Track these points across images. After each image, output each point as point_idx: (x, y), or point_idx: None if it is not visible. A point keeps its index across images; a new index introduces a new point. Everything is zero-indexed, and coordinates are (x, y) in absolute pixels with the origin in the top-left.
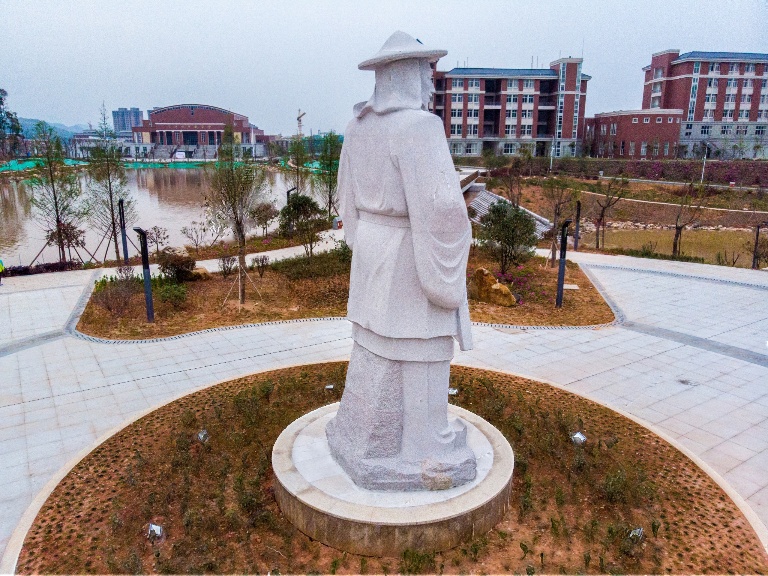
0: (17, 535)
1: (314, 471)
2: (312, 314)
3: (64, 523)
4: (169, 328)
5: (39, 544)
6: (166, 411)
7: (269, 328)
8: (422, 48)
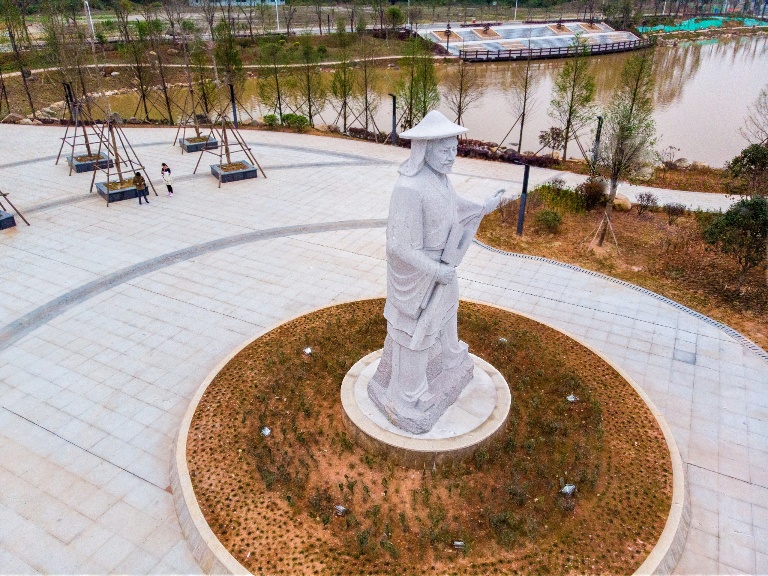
0: (284, 321)
1: (372, 371)
2: (642, 280)
3: (299, 326)
4: (521, 245)
5: (283, 329)
6: None
7: (581, 276)
8: (423, 132)
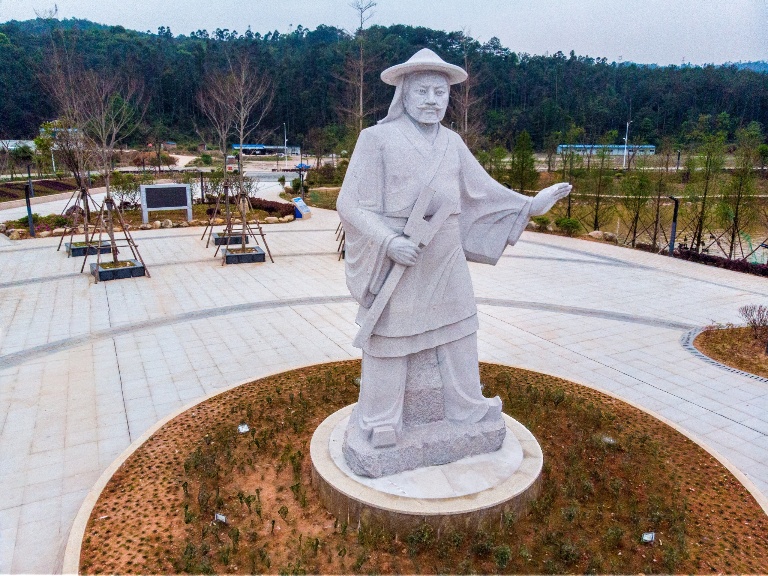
0: None
1: None
2: None
3: None
4: (761, 365)
5: None
6: (523, 372)
7: None
8: None
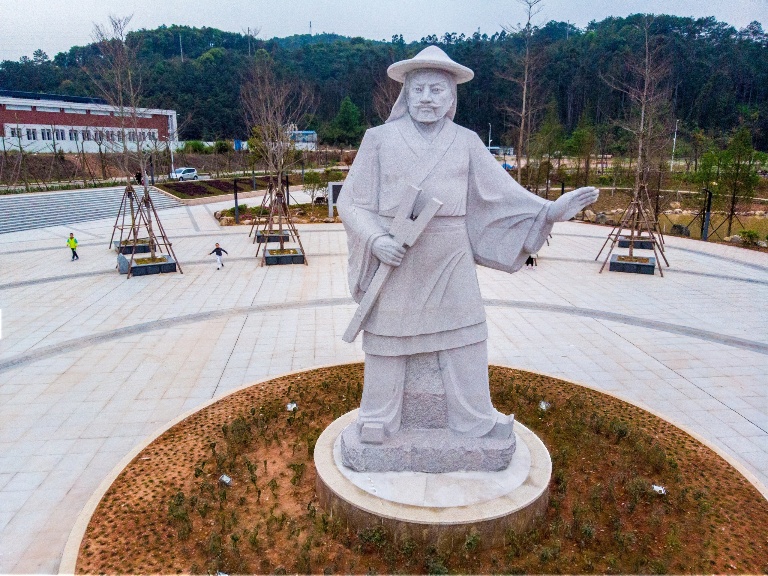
0: None
1: None
2: None
3: None
4: None
5: None
6: (607, 399)
7: None
8: None
